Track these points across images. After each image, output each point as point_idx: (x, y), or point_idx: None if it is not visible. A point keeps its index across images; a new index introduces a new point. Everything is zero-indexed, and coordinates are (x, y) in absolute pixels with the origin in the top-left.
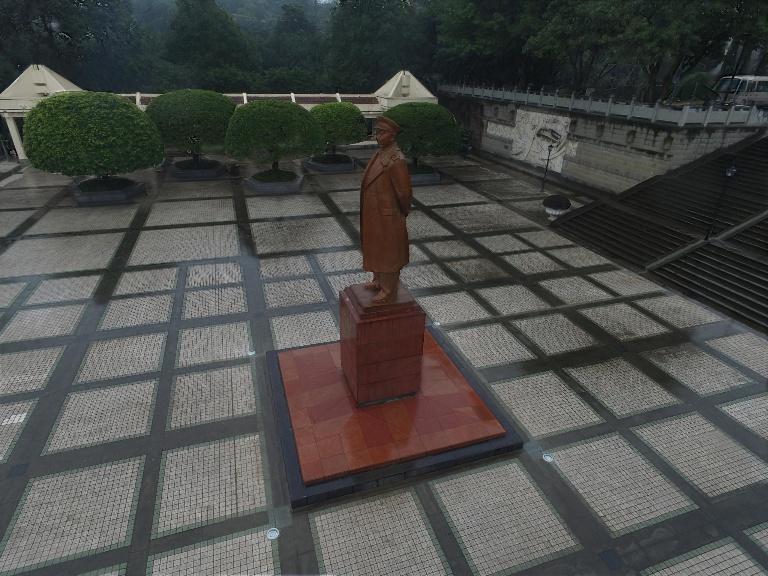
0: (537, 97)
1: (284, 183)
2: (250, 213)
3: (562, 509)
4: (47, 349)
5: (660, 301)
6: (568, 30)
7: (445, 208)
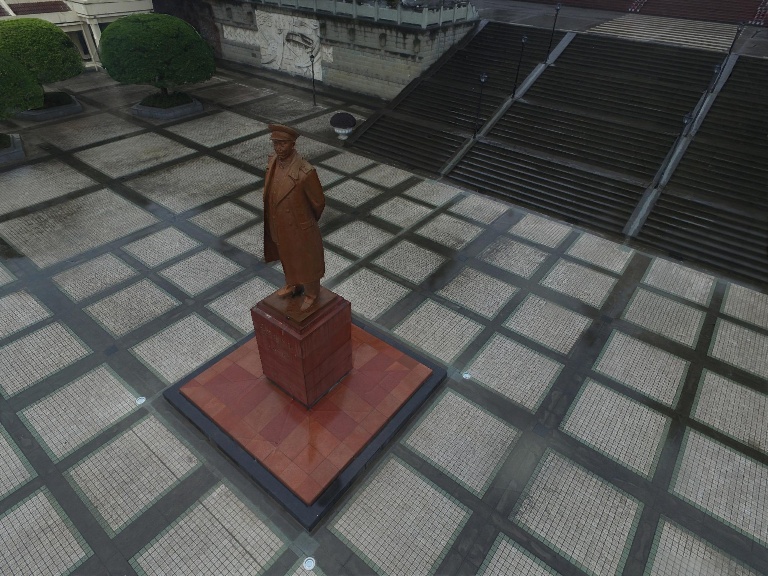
0: None
1: None
2: None
3: (496, 411)
4: None
5: (465, 203)
6: None
7: (232, 146)
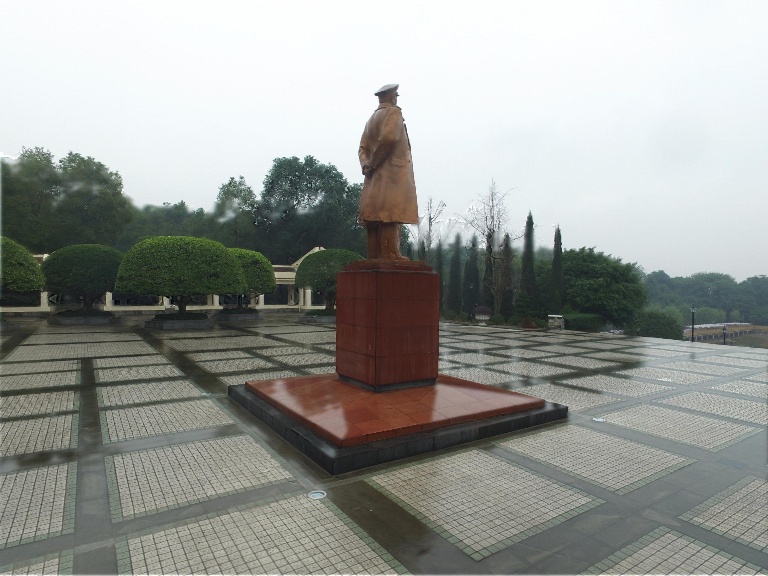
0: None
1: None
2: None
3: None
4: None
5: None
6: None
7: None
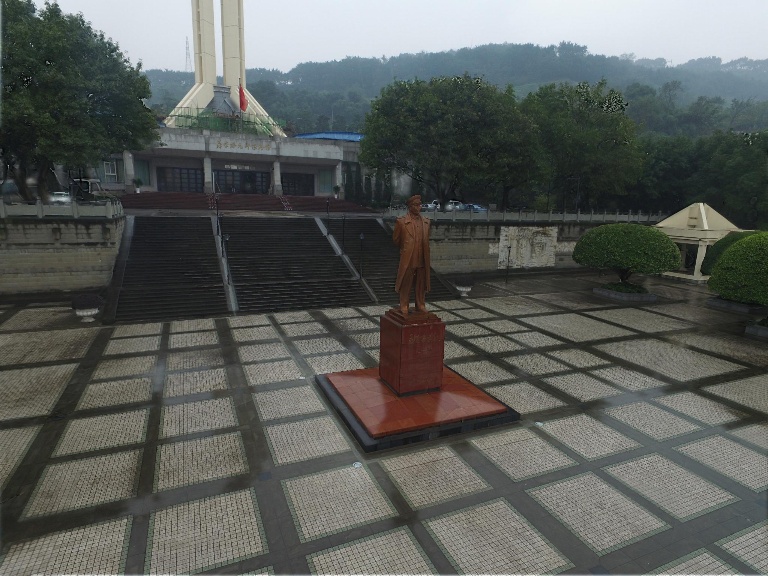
0: None
1: None
2: None
3: None
4: None
5: (281, 318)
6: None
7: None
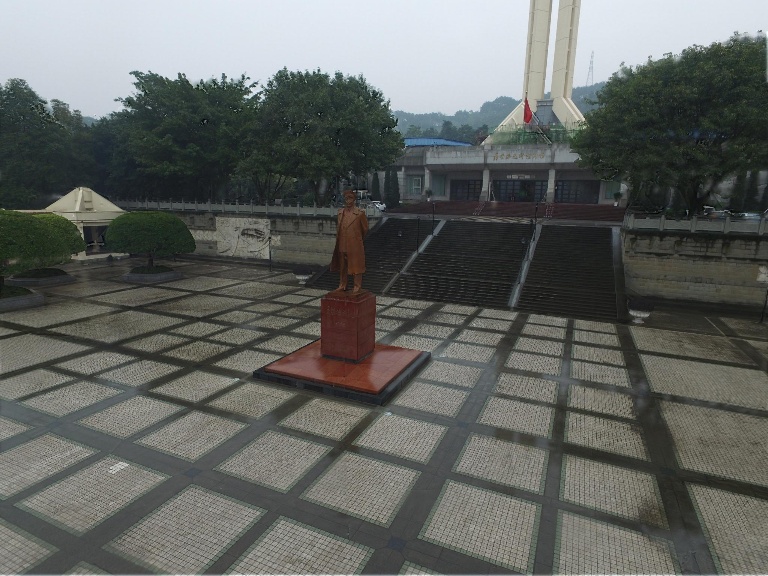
0: (233, 206)
1: (23, 297)
2: (26, 324)
3: (466, 364)
4: (31, 441)
5: (405, 303)
6: (265, 159)
7: (219, 290)
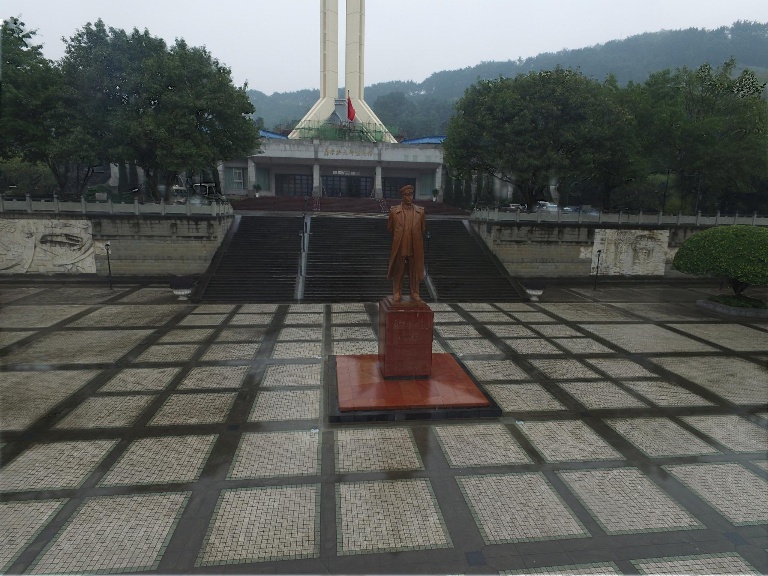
0: (21, 203)
1: None
2: None
3: None
4: None
5: (336, 307)
6: None
7: (76, 321)
